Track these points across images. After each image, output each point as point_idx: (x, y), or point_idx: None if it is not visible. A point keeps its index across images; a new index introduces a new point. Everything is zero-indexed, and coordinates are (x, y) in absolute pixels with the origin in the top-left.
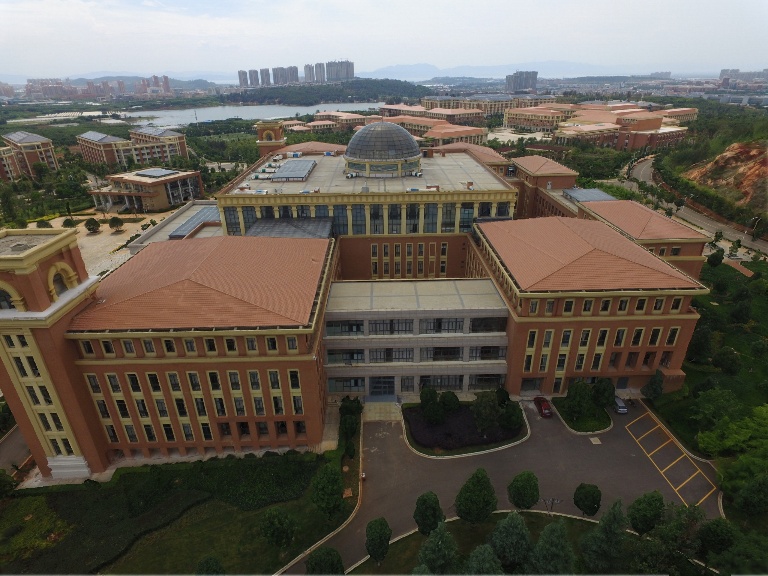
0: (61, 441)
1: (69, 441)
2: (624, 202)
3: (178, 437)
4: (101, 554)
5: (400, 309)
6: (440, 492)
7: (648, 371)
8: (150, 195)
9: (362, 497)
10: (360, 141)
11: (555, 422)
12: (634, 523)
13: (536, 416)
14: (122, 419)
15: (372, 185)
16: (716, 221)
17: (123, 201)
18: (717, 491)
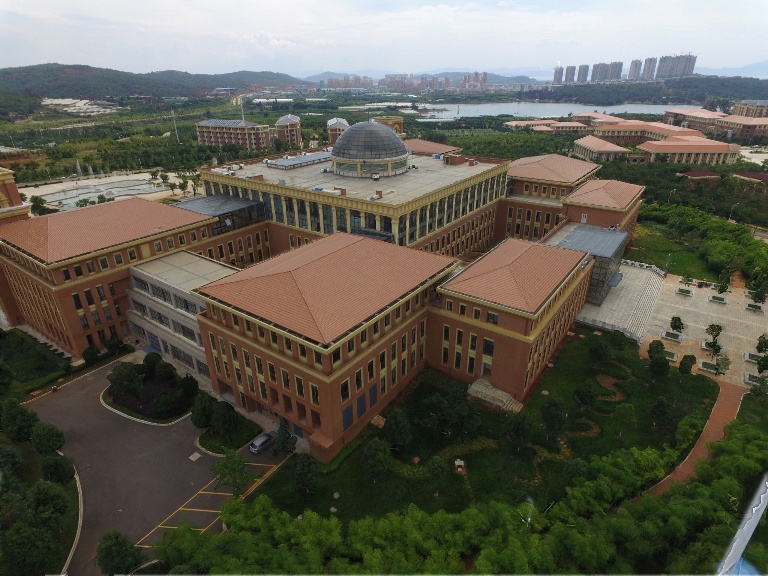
0: None
1: None
2: (527, 246)
3: (36, 321)
4: None
5: (164, 281)
6: (64, 422)
7: (305, 426)
8: None
9: (37, 399)
10: None
11: None
12: None
13: None
14: (19, 298)
15: (318, 181)
16: None
17: None
18: None
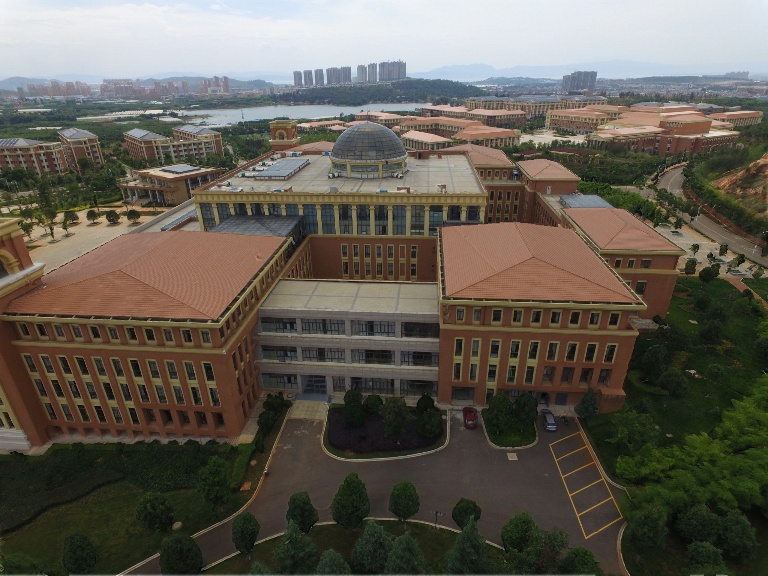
0: (2, 414)
1: (9, 415)
2: (605, 210)
3: (108, 419)
4: (7, 521)
5: (331, 309)
6: None
7: (586, 388)
8: (171, 190)
9: (259, 492)
10: (343, 141)
11: (477, 434)
12: (504, 544)
13: (460, 426)
14: (58, 398)
15: (348, 185)
16: (734, 233)
17: (148, 195)
18: (622, 521)
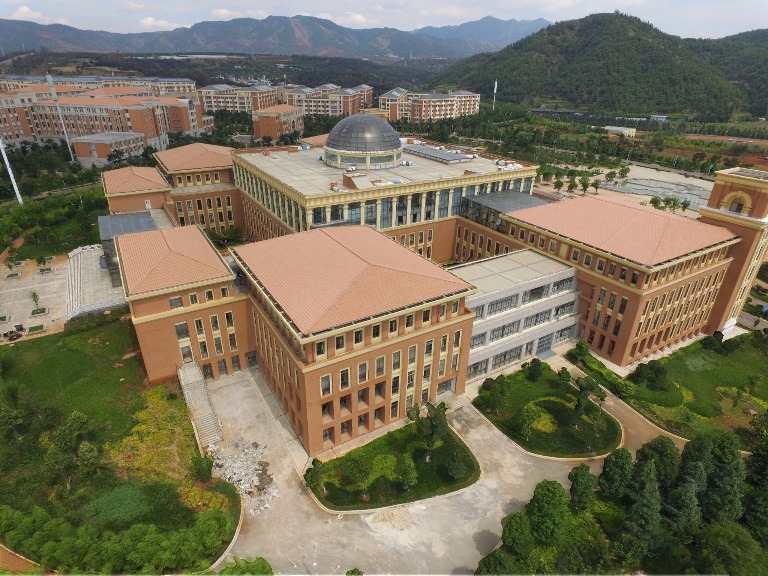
0: None
1: None
2: (137, 174)
3: None
4: None
5: None
6: None
7: None
8: None
9: None
10: None
11: None
12: None
13: None
14: None
15: None
16: None
17: None
18: None
